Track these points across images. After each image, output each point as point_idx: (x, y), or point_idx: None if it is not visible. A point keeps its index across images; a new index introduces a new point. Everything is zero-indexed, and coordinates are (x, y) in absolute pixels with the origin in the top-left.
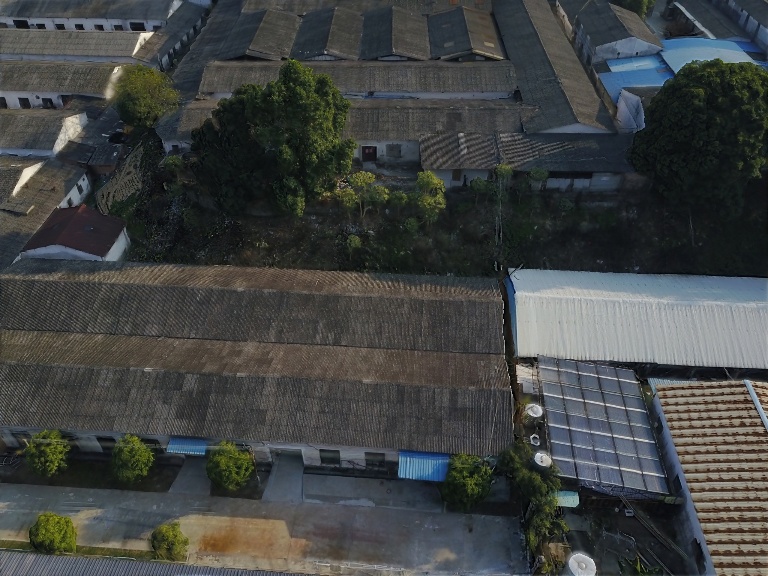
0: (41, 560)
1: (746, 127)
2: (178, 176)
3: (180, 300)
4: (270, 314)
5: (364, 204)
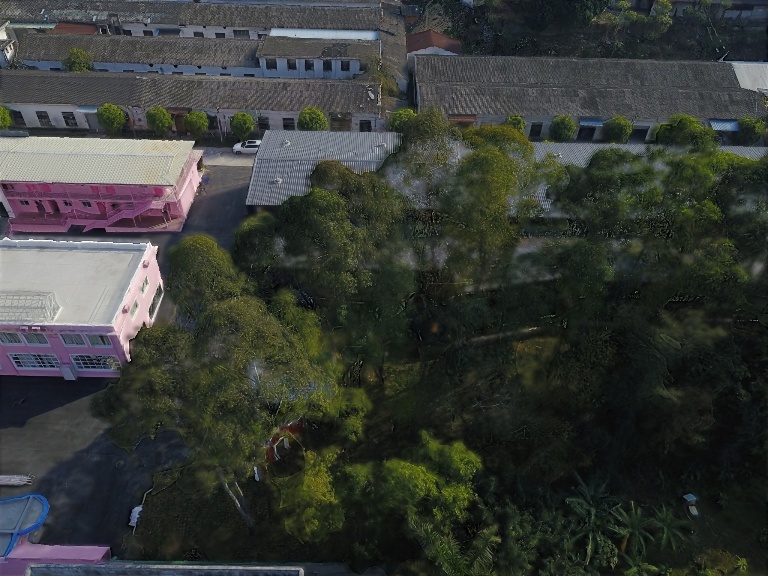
0: (572, 144)
1: None
2: (491, 11)
3: (541, 66)
4: (598, 72)
5: (619, 24)
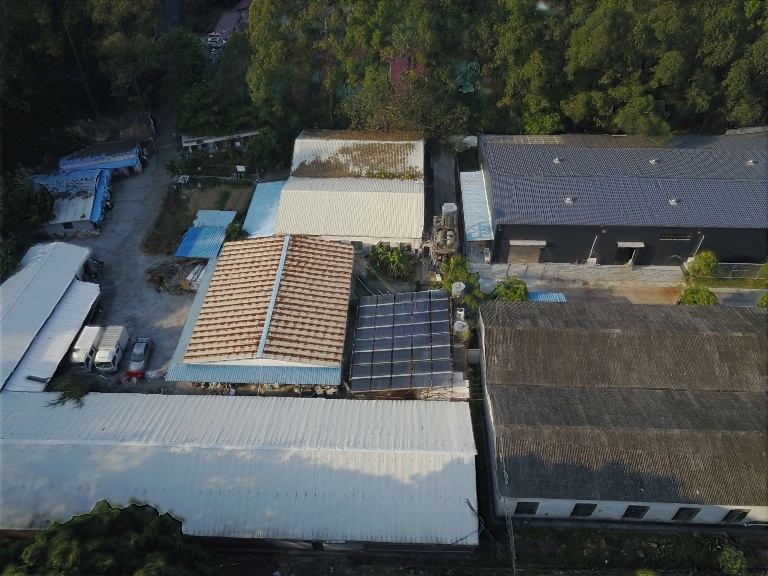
0: None
1: (84, 538)
2: None
3: None
4: (763, 413)
5: None
